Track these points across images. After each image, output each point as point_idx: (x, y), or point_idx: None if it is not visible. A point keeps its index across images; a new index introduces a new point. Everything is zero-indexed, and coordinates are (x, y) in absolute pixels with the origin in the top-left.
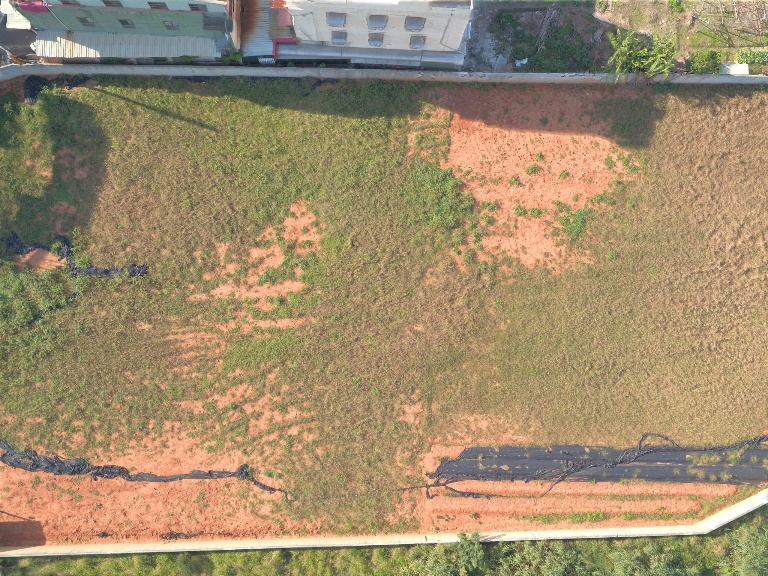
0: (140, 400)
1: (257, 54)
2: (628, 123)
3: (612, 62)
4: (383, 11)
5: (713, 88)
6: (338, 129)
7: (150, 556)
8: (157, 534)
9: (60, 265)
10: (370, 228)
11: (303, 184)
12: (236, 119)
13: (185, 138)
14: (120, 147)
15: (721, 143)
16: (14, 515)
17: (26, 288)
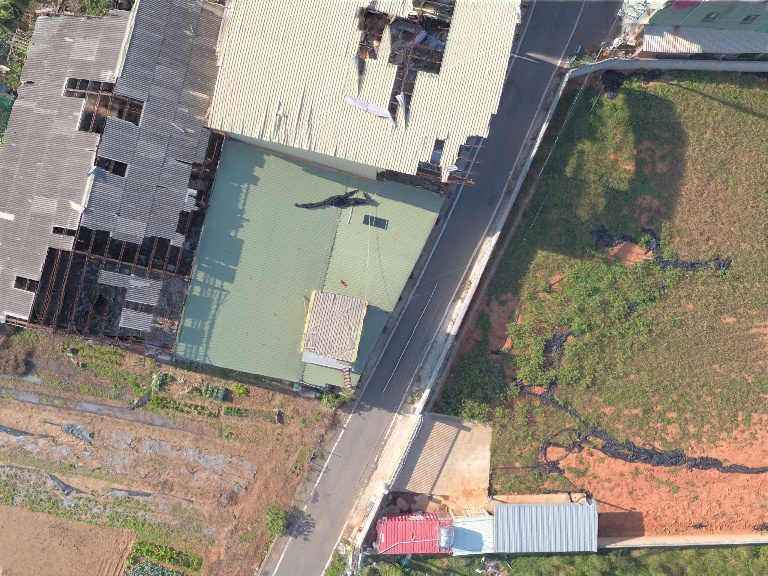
0: (729, 392)
1: None
2: None
3: None
4: None
5: None
6: None
7: (755, 547)
8: (750, 525)
9: (647, 258)
10: None
11: None
12: None
13: (760, 133)
14: (698, 142)
15: None
16: (616, 506)
17: (619, 281)
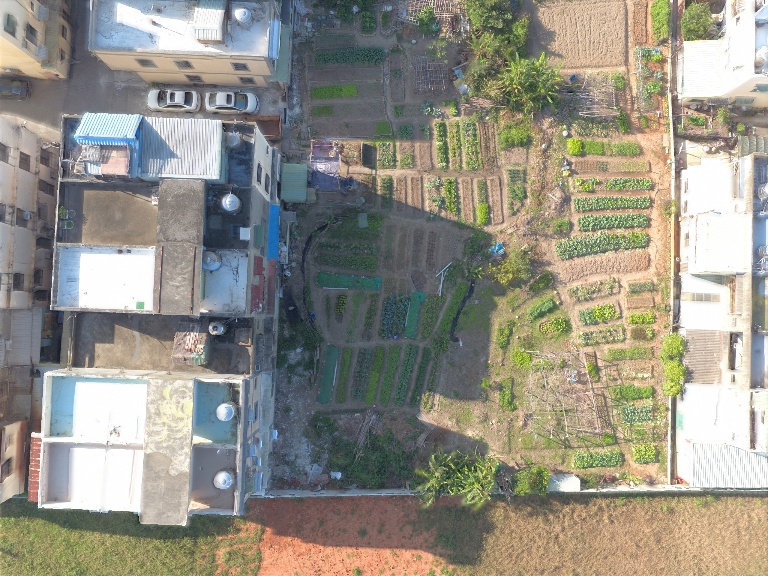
0: None
1: None
2: (452, 535)
3: (425, 492)
4: None
5: (547, 493)
6: (140, 550)
7: None
8: None
9: None
10: None
11: None
12: (33, 541)
13: None
14: None
15: (553, 556)
16: None
17: None
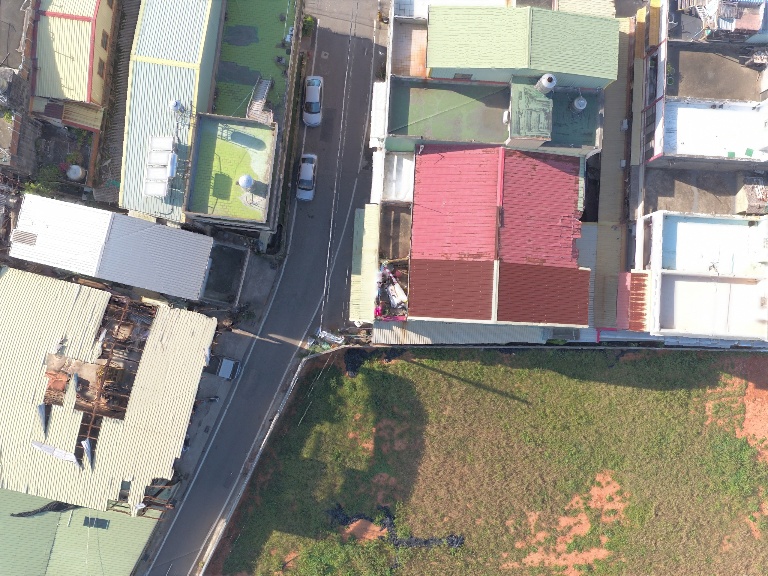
0: None
1: (580, 341)
2: None
3: None
4: (740, 338)
5: None
6: (642, 400)
7: None
8: None
9: (382, 535)
10: (673, 498)
11: (609, 454)
12: (546, 391)
13: (499, 411)
14: (437, 419)
15: None
16: None
17: (352, 559)
